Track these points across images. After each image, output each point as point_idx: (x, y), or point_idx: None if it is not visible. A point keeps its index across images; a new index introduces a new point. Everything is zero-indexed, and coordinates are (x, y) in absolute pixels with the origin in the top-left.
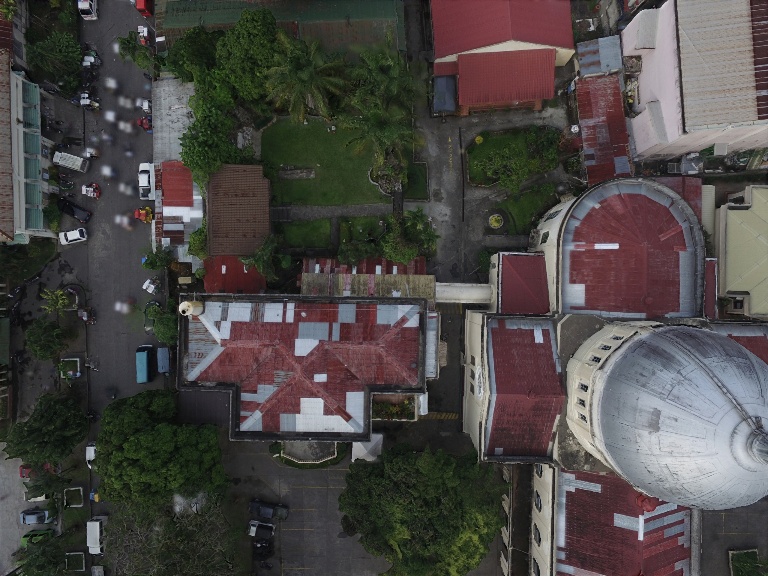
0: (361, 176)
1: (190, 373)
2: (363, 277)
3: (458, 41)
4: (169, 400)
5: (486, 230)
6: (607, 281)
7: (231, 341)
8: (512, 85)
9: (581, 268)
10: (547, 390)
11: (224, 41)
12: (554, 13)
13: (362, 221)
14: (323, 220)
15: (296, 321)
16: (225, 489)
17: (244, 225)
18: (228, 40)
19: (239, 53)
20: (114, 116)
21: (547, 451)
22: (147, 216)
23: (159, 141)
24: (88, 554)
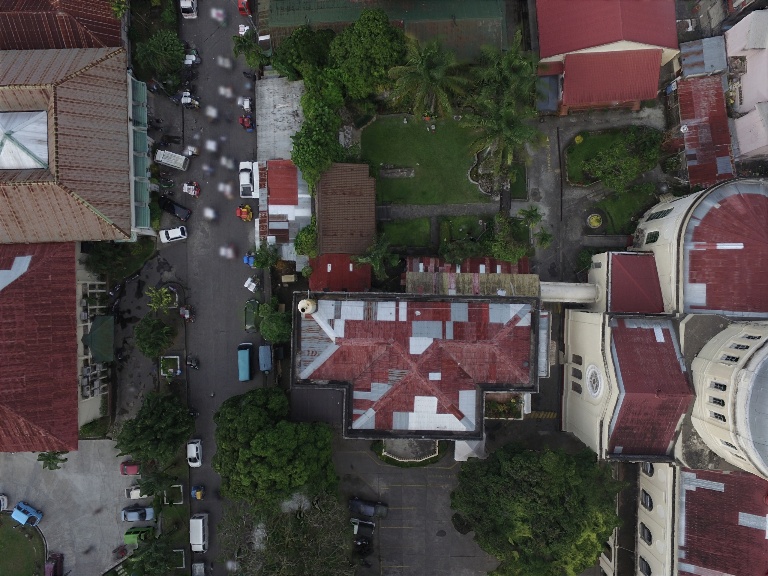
0: (460, 175)
1: (303, 371)
2: (467, 276)
3: (565, 41)
4: (284, 398)
5: (584, 230)
6: (730, 281)
7: (346, 339)
8: (617, 85)
9: (702, 268)
10: (675, 389)
11: (341, 40)
12: (660, 13)
13: (461, 220)
14: (422, 219)
15: (409, 319)
16: (336, 487)
17: (351, 224)
18: (347, 39)
19: (360, 52)
20: (213, 114)
21: (666, 450)
22: (247, 214)
23: (263, 140)
24: (187, 551)
